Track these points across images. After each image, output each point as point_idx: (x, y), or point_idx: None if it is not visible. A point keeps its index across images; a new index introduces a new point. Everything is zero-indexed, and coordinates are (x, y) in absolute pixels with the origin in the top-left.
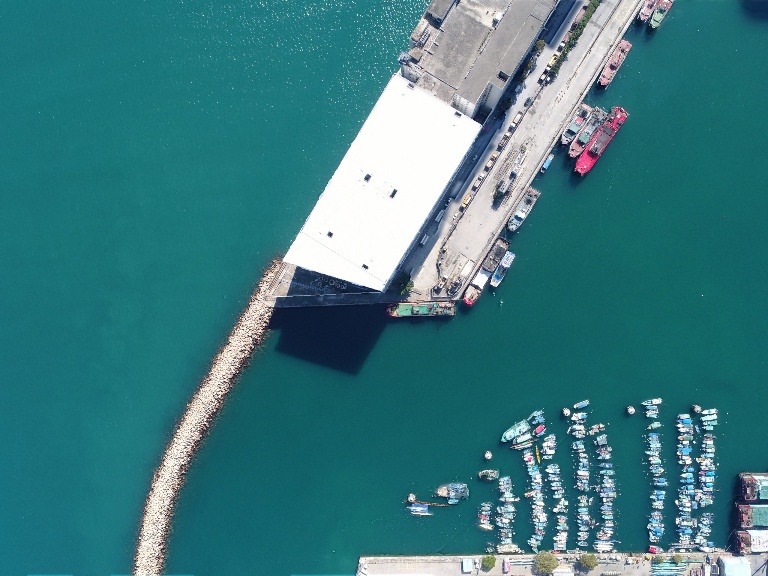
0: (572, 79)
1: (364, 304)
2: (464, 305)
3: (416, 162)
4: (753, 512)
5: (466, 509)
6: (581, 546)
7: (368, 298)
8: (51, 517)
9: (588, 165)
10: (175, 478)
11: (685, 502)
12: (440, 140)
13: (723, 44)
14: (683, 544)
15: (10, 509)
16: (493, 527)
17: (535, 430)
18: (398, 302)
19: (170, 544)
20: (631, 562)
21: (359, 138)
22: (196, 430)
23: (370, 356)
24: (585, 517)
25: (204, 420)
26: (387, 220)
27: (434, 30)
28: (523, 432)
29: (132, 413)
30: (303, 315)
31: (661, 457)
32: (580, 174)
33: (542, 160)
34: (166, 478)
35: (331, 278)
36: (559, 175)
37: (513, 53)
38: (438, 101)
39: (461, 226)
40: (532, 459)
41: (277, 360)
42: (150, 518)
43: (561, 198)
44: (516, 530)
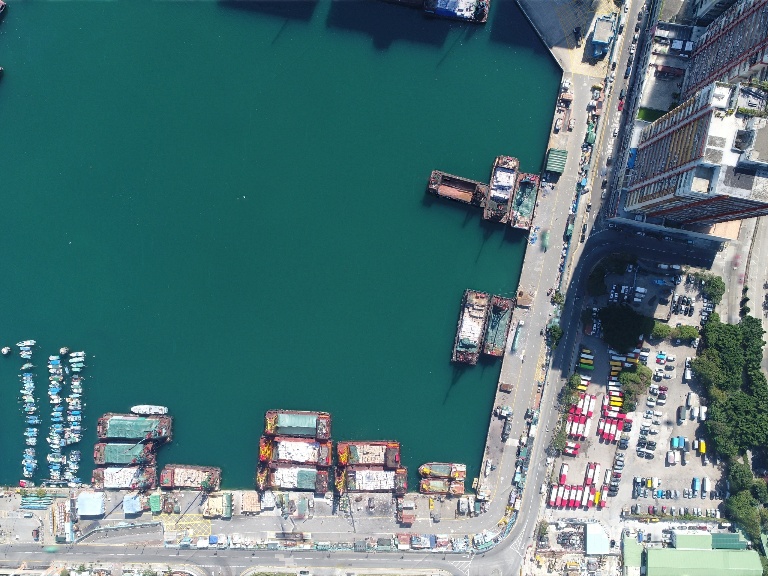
0: None
1: None
2: None
3: None
4: (105, 449)
5: None
6: None
7: None
8: None
9: None
10: None
11: (55, 440)
12: None
13: (91, 4)
14: (54, 480)
15: None
16: None
17: None
18: None
19: None
20: (2, 495)
21: None
22: None
23: None
24: None
25: None
26: None
27: None
28: None
29: None
30: None
31: (35, 396)
32: None
33: None
34: None
35: None
36: None
37: None
38: None
39: None
40: None
41: None
42: None
43: None
44: None
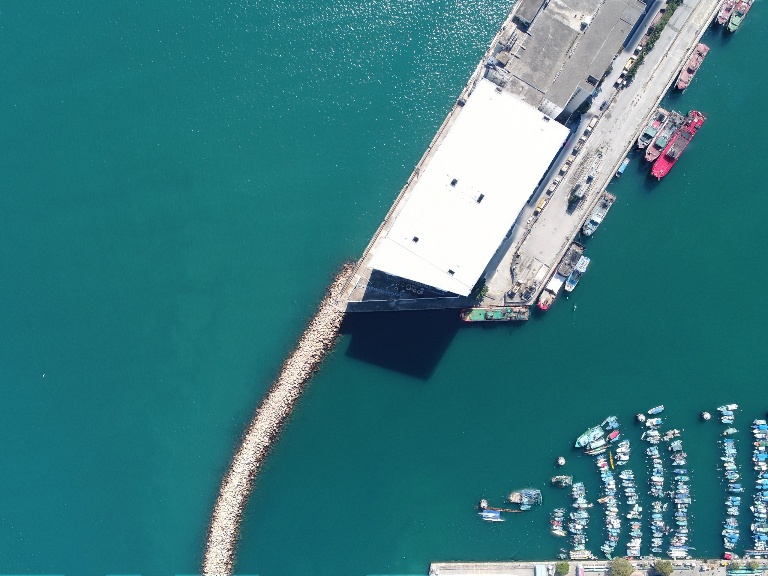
0: (648, 83)
1: (436, 309)
2: (537, 310)
3: (503, 167)
4: None
5: (538, 515)
6: (655, 552)
7: (441, 303)
8: (123, 523)
9: (665, 169)
10: (244, 484)
11: (761, 508)
12: (528, 145)
13: None
14: (758, 550)
15: (82, 515)
16: (566, 533)
17: (609, 436)
18: (471, 307)
19: (238, 550)
20: (706, 569)
21: (445, 142)
22: (266, 435)
23: (442, 361)
24: (659, 523)
25: (274, 425)
26: (474, 225)
27: (521, 34)
28: (597, 438)
29: (200, 418)
30: (375, 320)
31: (736, 463)
32: (657, 178)
33: (618, 164)
34: (235, 484)
35: (407, 283)
36: (635, 179)
37: (602, 57)
38: (526, 105)
39: (535, 230)
40: (606, 465)
41: (347, 365)
42: (219, 524)
43: (636, 202)
44: (589, 536)
